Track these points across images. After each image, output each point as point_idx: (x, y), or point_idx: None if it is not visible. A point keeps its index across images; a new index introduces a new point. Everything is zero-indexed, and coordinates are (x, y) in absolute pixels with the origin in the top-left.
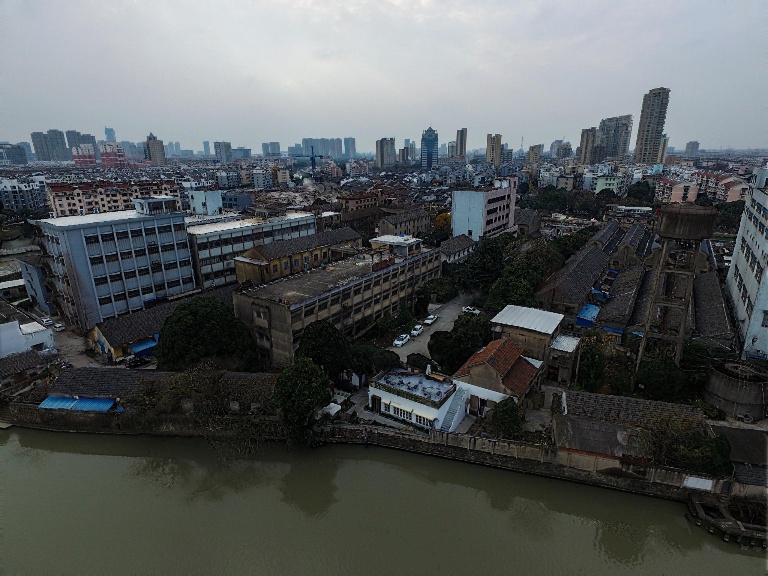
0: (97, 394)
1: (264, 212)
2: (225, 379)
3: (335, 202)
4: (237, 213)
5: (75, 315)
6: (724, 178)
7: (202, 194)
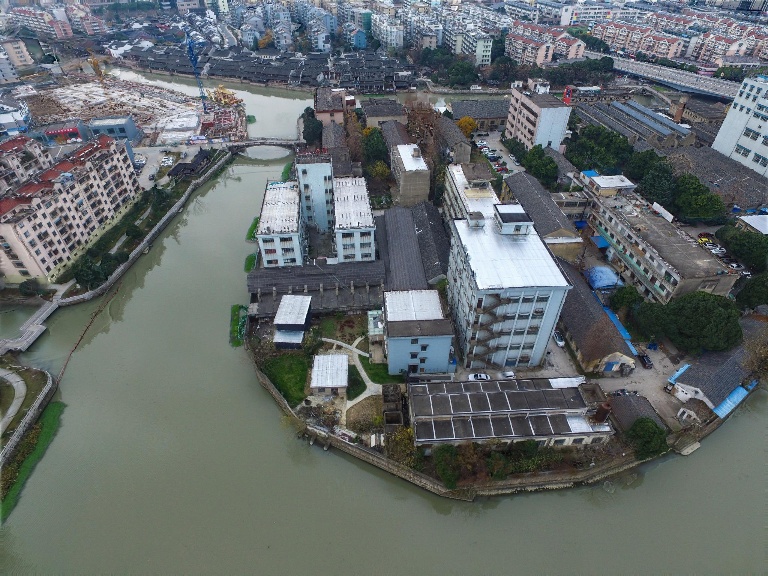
0: (734, 388)
1: (486, 182)
2: (759, 337)
3: (200, 97)
4: (357, 177)
5: (520, 357)
6: (558, 34)
7: (325, 166)
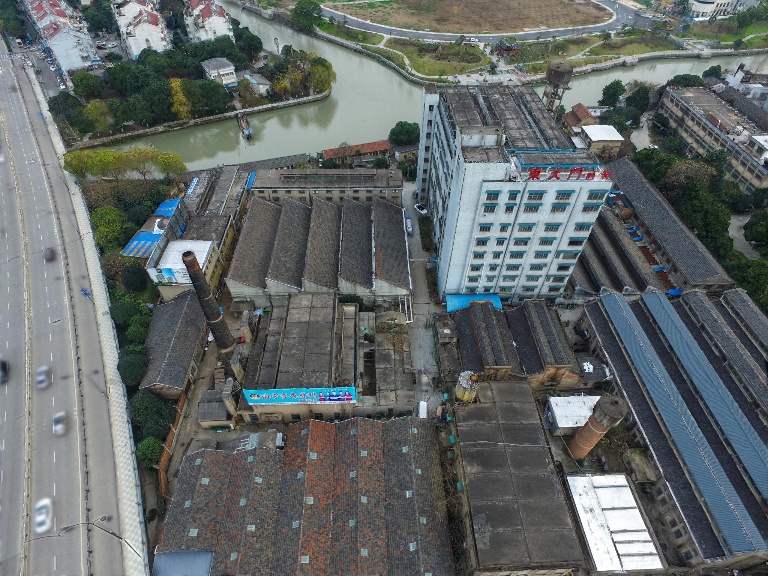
0: None
1: None
2: None
3: None
4: None
5: None
6: None
7: None
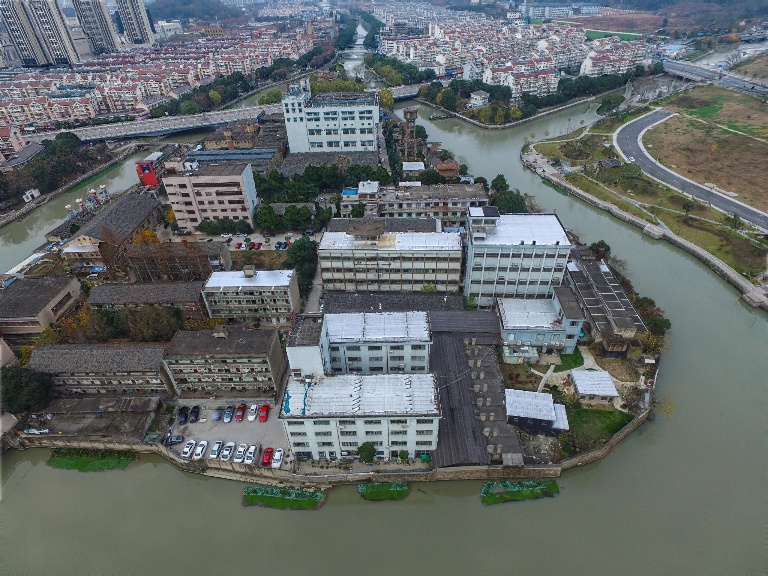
0: None
1: None
2: None
3: None
4: None
5: None
6: None
7: None
